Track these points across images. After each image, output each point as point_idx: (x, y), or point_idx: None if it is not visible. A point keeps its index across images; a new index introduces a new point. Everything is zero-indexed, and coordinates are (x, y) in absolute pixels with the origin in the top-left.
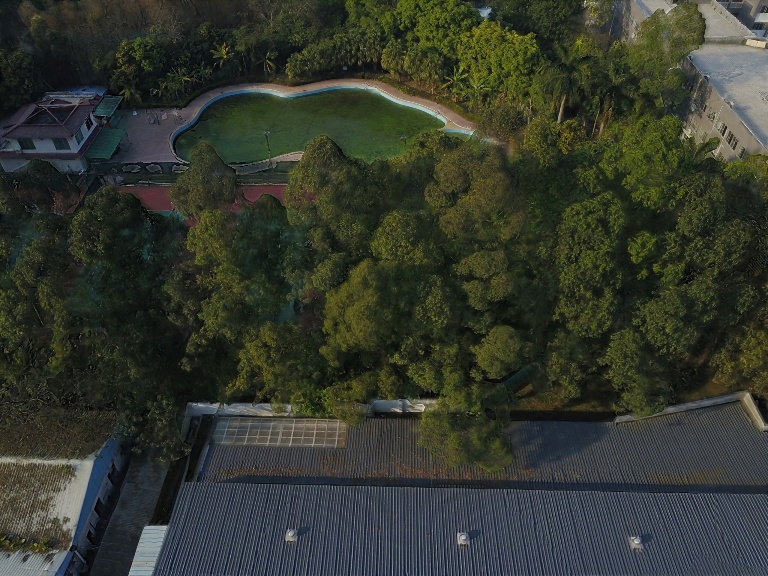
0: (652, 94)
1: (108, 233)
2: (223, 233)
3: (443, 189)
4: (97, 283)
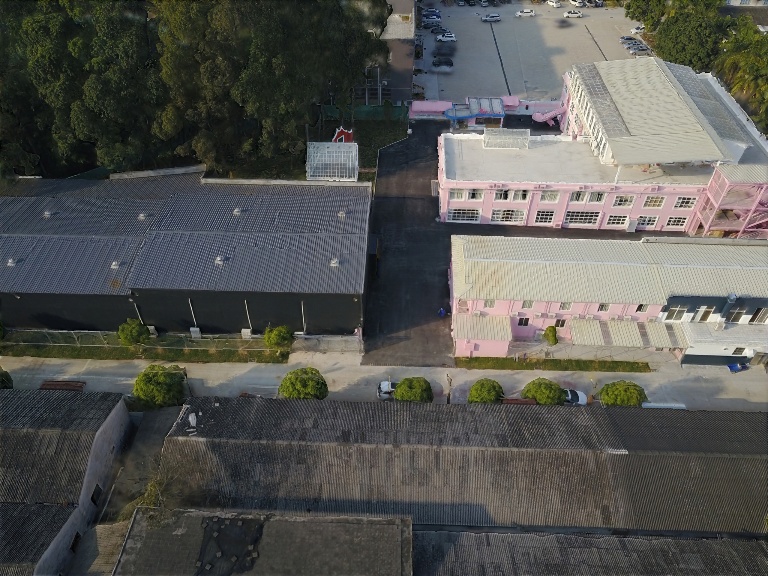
0: None
1: None
2: None
3: None
4: None
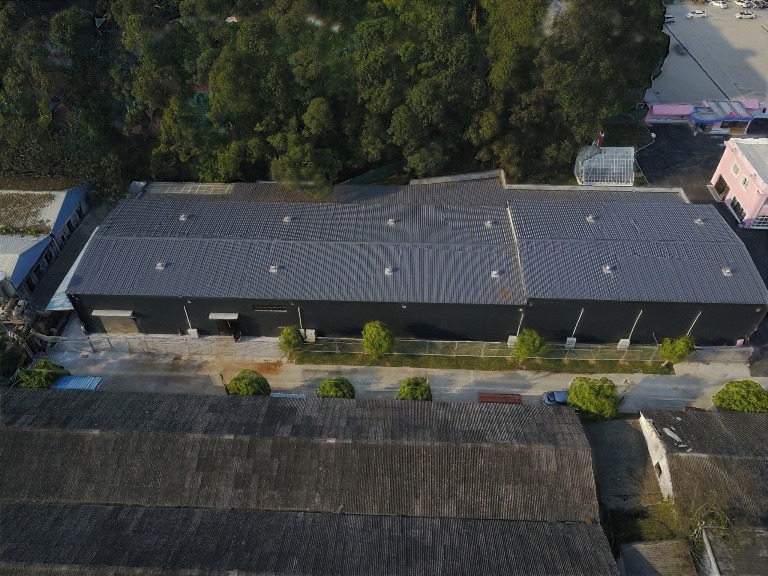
0: (498, 3)
1: (73, 28)
2: (142, 29)
3: (278, 8)
4: (69, 74)
